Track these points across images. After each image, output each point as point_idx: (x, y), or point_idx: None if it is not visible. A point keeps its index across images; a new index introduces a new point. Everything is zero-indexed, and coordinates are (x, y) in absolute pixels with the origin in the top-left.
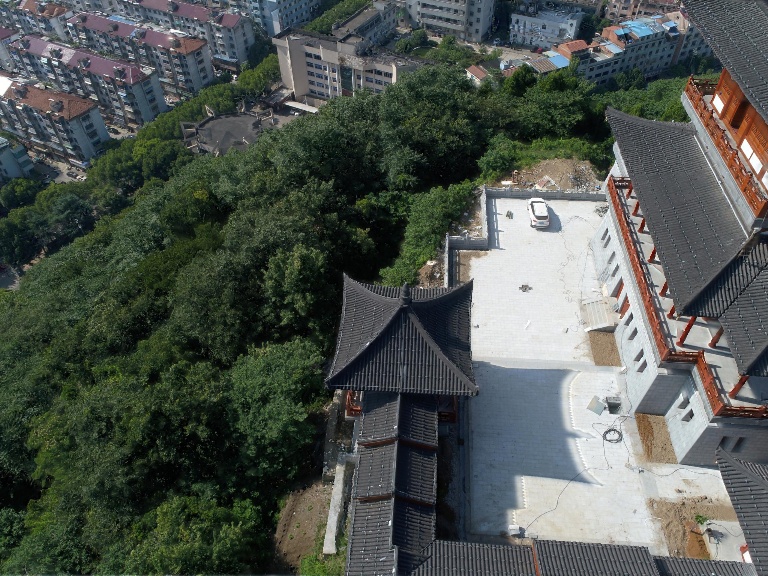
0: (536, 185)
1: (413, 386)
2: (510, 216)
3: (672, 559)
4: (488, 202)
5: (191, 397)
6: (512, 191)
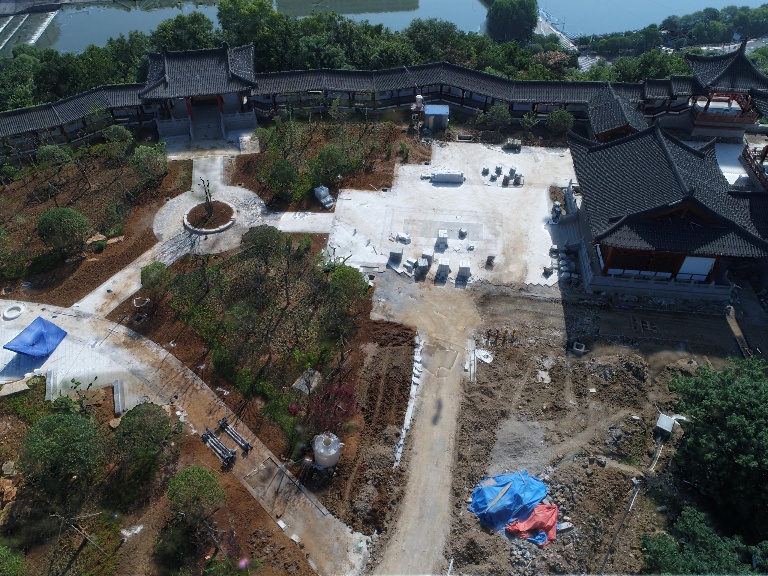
0: None
1: (700, 76)
2: None
3: None
4: None
5: (666, 60)
6: None
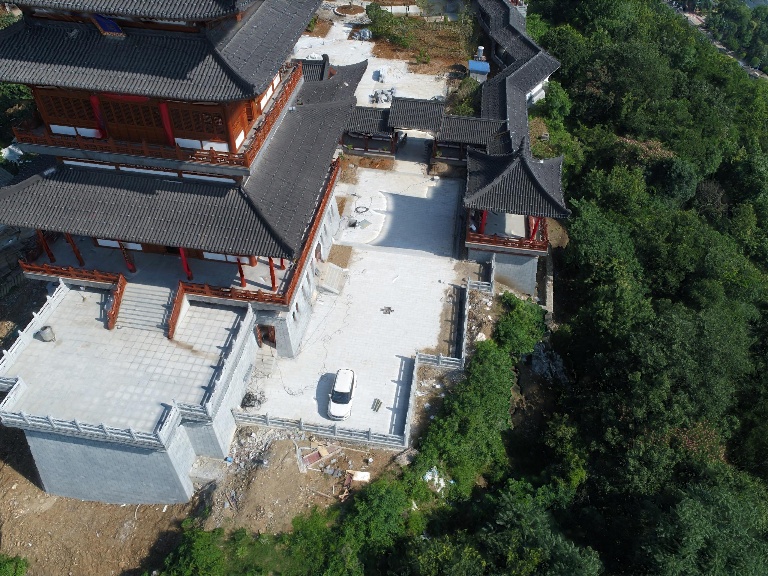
0: (324, 455)
1: None
2: (378, 401)
3: (374, 131)
4: (400, 431)
5: (655, 219)
6: (366, 433)
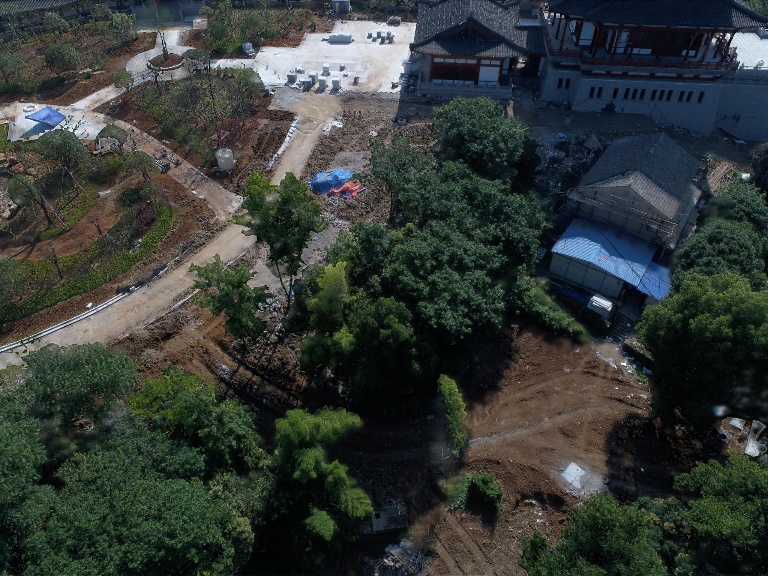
0: None
1: None
2: None
3: None
4: None
5: None
6: None
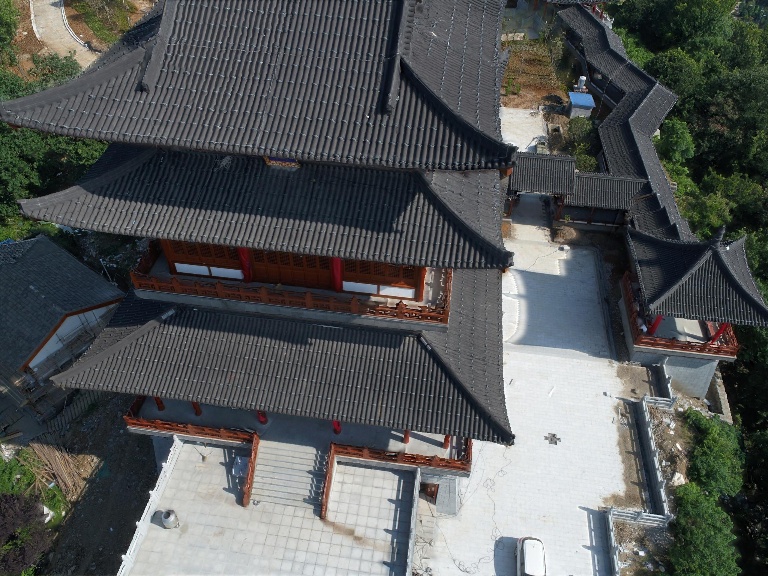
0: None
1: None
2: None
3: None
4: None
5: None
6: None
